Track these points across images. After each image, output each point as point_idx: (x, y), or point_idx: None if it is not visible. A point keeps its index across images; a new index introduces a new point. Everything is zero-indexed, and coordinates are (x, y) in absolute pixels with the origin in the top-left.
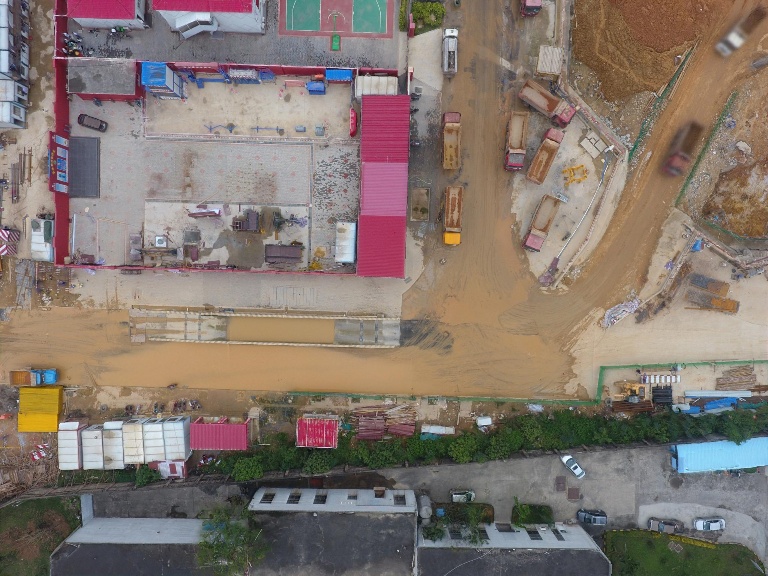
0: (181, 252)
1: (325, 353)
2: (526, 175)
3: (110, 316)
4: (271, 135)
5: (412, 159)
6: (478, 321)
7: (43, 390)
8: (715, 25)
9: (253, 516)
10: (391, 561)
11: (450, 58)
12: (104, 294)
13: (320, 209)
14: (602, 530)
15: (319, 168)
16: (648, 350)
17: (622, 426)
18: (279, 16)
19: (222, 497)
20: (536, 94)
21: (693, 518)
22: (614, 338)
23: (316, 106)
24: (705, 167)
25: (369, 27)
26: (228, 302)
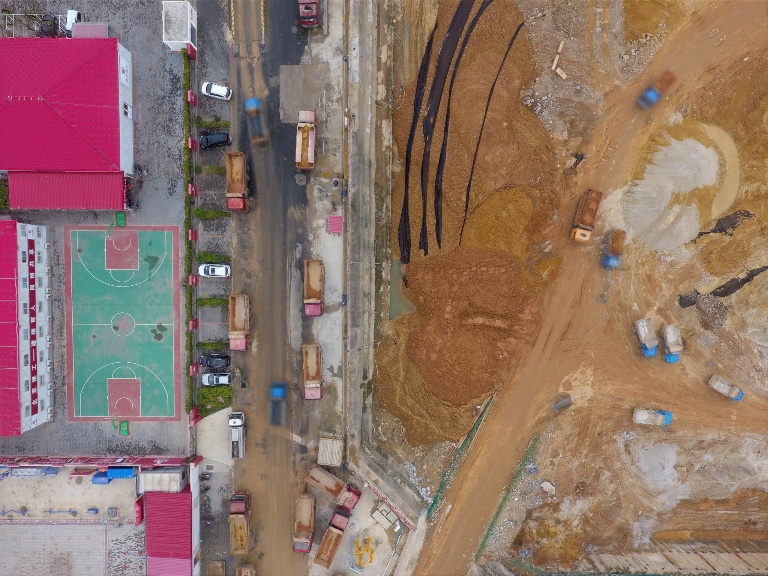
0: None
1: None
2: None
3: None
4: (64, 516)
5: (206, 534)
6: None
7: None
8: (515, 371)
9: None
10: None
11: (234, 447)
12: None
13: None
14: None
15: (114, 546)
16: None
17: None
18: (67, 403)
19: None
20: (323, 474)
21: None
22: None
23: (108, 487)
24: (507, 514)
25: (157, 411)
26: None
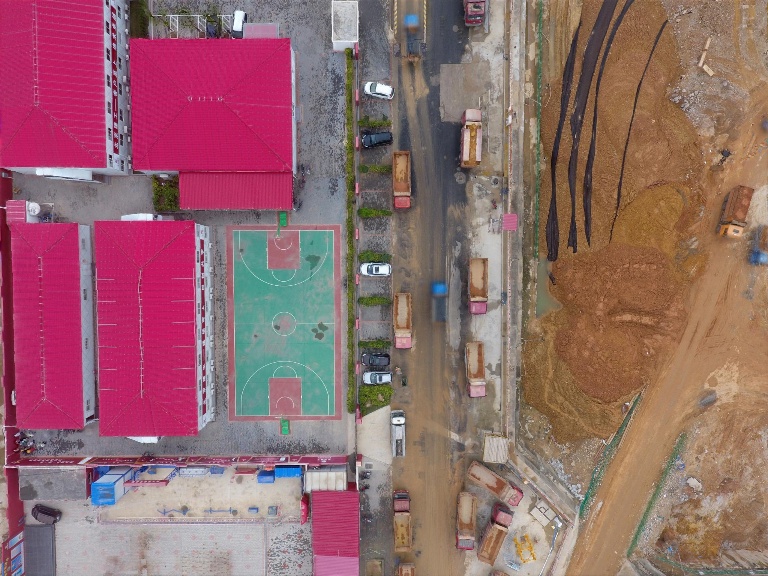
0: None
1: None
2: (477, 554)
3: None
4: (224, 516)
5: (365, 532)
6: None
7: None
8: (662, 367)
9: None
10: None
11: (398, 446)
12: None
13: None
14: None
15: (273, 545)
16: None
17: None
18: (228, 403)
19: None
20: (484, 472)
21: None
22: None
23: (268, 486)
24: (656, 511)
25: (318, 410)
26: None
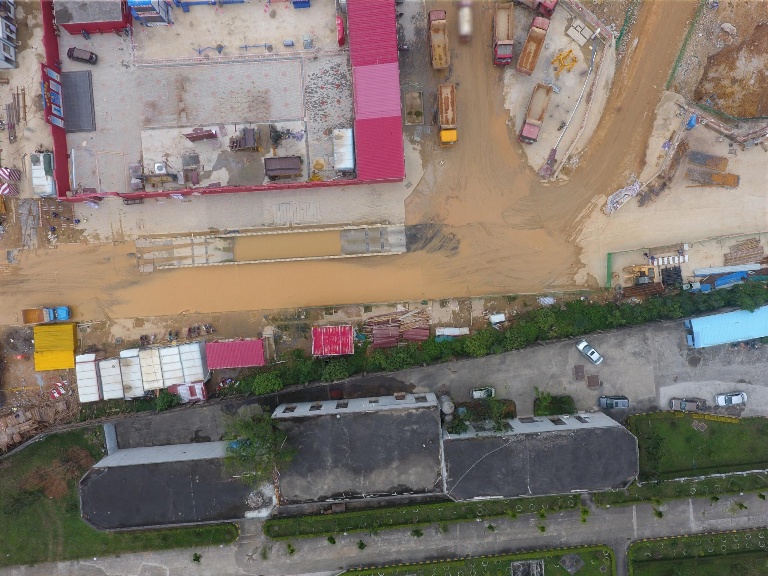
0: (181, 176)
1: (333, 266)
2: (516, 66)
3: (117, 248)
4: (260, 52)
5: (401, 64)
6: (482, 220)
7: (57, 327)
8: None
9: (277, 424)
10: (418, 457)
11: None
12: (109, 227)
13: (315, 122)
14: (625, 415)
15: (310, 81)
16: (653, 233)
17: (635, 307)
18: None
19: (244, 417)
20: None
21: (714, 395)
22: (618, 224)
23: (302, 20)
24: (692, 50)
25: None
26: (232, 224)
